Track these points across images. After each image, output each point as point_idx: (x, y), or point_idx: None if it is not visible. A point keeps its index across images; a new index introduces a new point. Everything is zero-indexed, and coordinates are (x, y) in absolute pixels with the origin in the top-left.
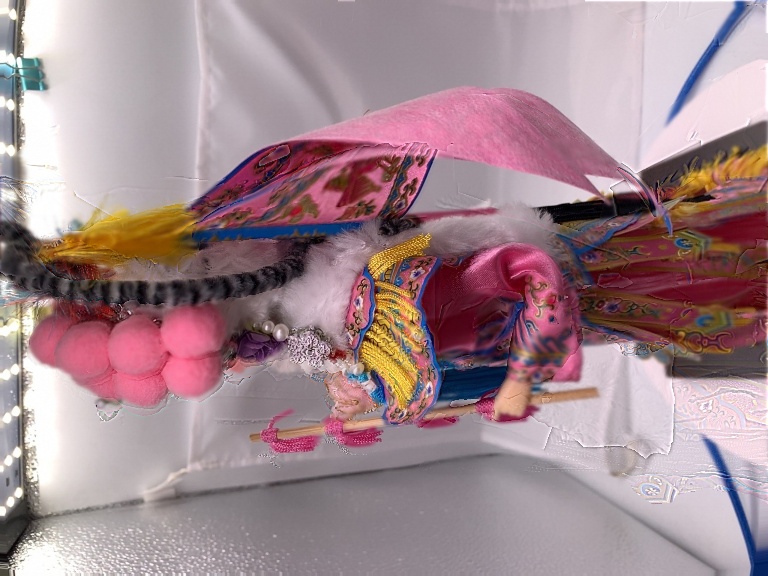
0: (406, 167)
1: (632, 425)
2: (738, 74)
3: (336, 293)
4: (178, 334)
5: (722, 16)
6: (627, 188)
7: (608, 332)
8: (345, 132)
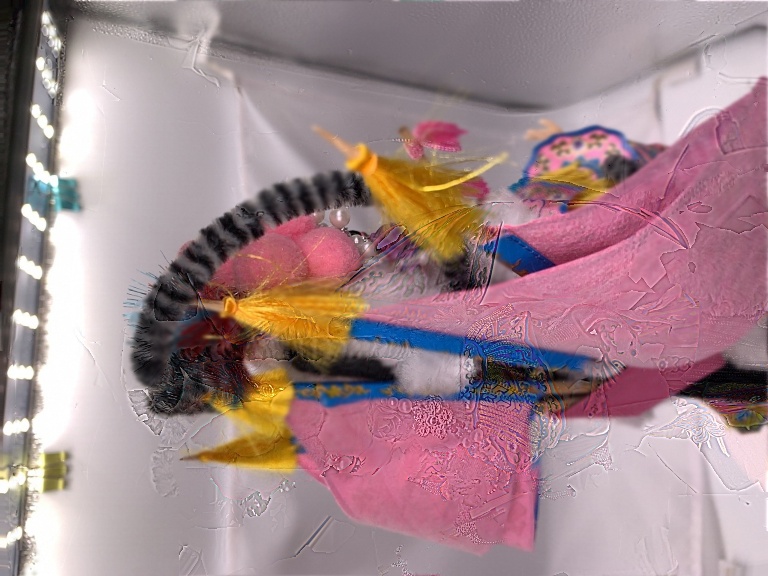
0: (478, 255)
1: (762, 278)
2: None
3: (447, 360)
4: (336, 386)
5: (653, 184)
6: None
7: (677, 395)
8: None
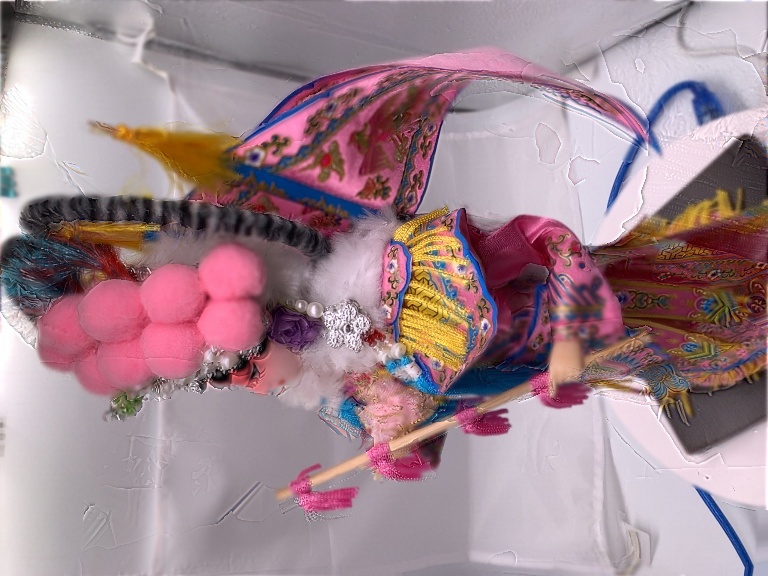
0: (413, 153)
1: (726, 83)
2: None
3: (368, 261)
4: (220, 262)
5: (622, 151)
6: None
7: None
8: None
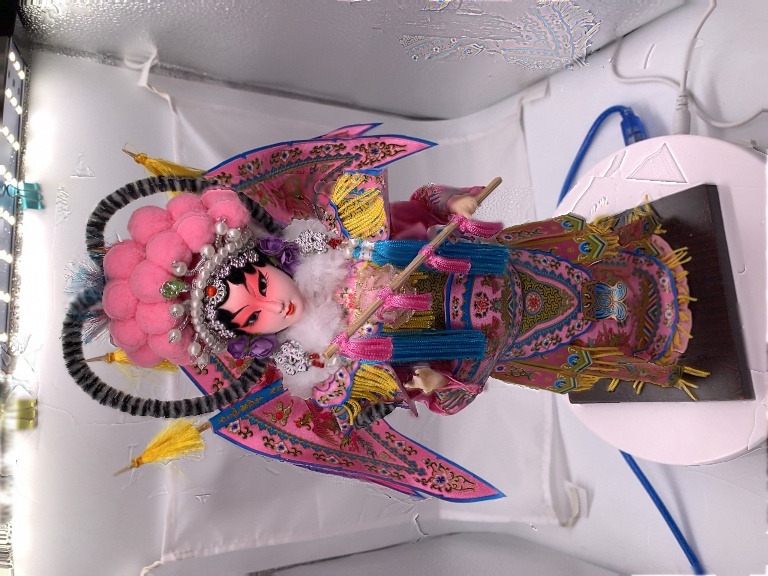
0: None
1: None
2: None
3: (310, 223)
4: None
5: None
6: None
7: (539, 253)
8: None
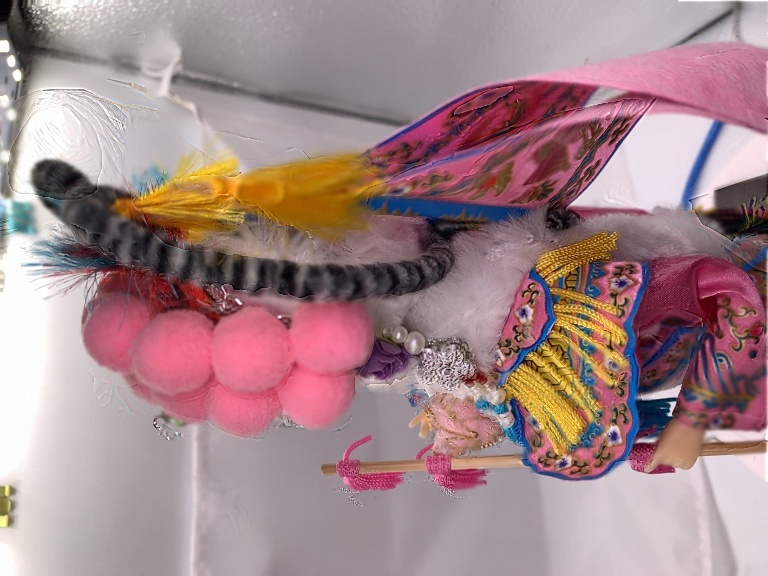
0: (600, 143)
1: None
2: None
3: (496, 298)
4: (320, 340)
5: None
6: (712, 202)
7: None
8: (603, 77)
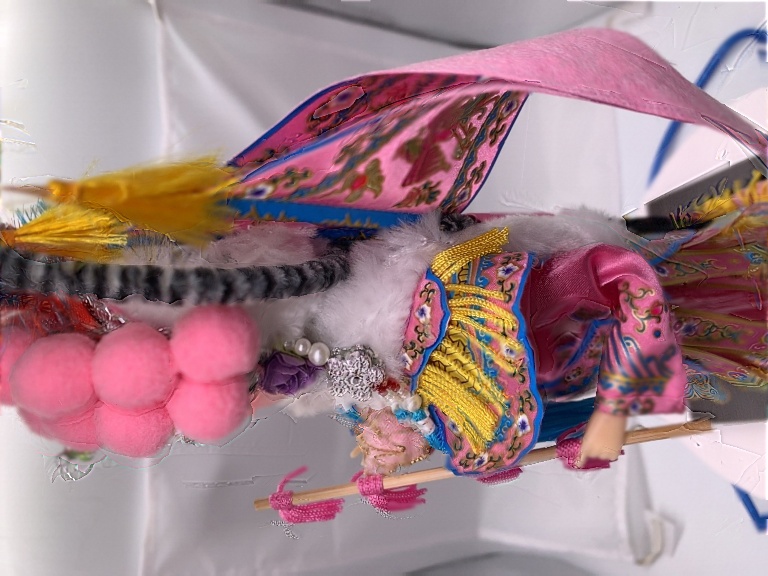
0: (478, 144)
1: None
2: (767, 91)
3: (393, 301)
4: (198, 346)
5: (724, 45)
6: (643, 215)
7: None
8: (441, 66)
